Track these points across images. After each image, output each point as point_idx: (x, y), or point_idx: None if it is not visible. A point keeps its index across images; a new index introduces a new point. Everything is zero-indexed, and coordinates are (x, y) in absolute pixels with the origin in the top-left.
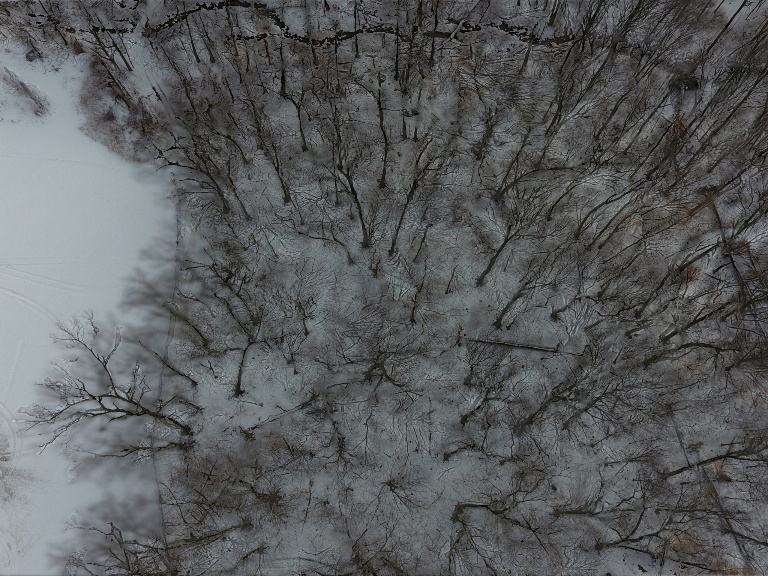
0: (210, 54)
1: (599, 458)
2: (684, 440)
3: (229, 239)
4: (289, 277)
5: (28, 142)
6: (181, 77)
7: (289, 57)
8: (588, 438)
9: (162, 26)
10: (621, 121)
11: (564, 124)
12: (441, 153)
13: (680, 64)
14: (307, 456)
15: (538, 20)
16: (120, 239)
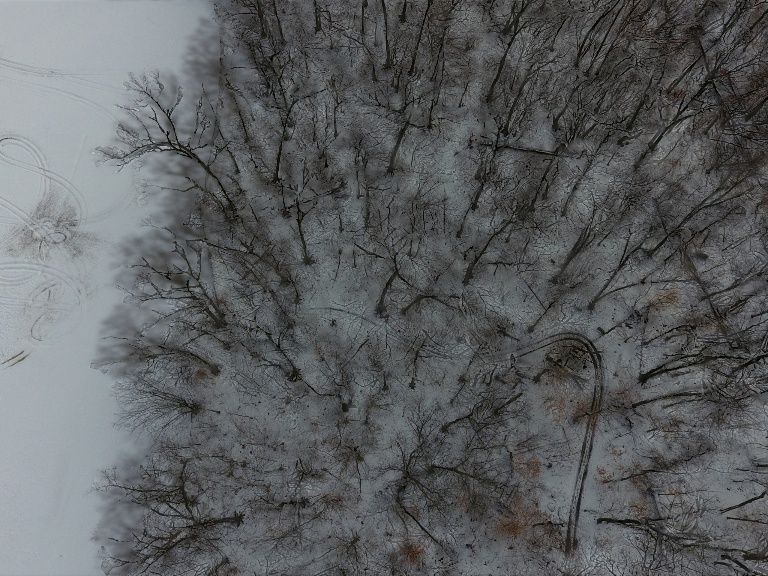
0: None
1: None
2: (668, 227)
3: (267, 58)
4: None
5: None
6: None
7: None
8: (583, 223)
9: None
10: None
11: None
12: None
13: None
14: (337, 230)
15: None
16: (170, 56)
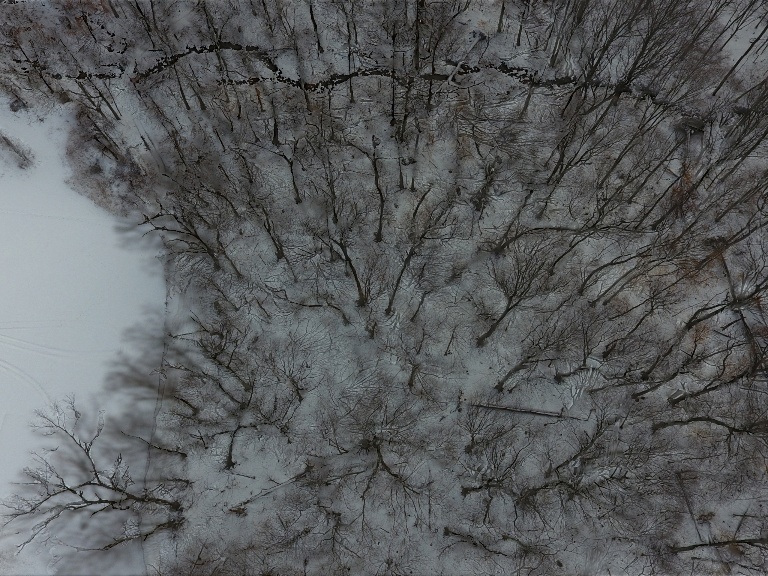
0: (200, 102)
1: (606, 532)
2: (695, 511)
3: (220, 299)
4: (282, 339)
5: (12, 197)
6: (170, 125)
7: (282, 103)
8: (594, 509)
9: (151, 71)
10: (625, 171)
11: (566, 173)
12: (439, 204)
13: (687, 120)
14: None
15: (538, 61)
16: (107, 300)
